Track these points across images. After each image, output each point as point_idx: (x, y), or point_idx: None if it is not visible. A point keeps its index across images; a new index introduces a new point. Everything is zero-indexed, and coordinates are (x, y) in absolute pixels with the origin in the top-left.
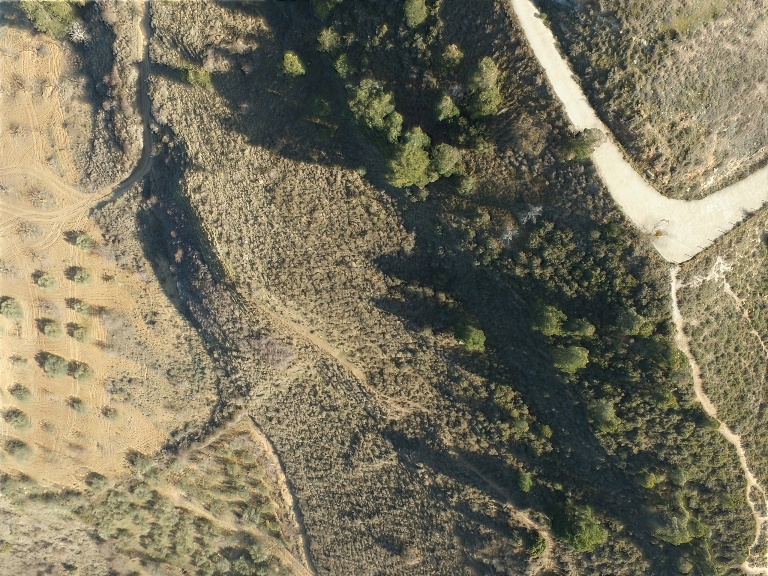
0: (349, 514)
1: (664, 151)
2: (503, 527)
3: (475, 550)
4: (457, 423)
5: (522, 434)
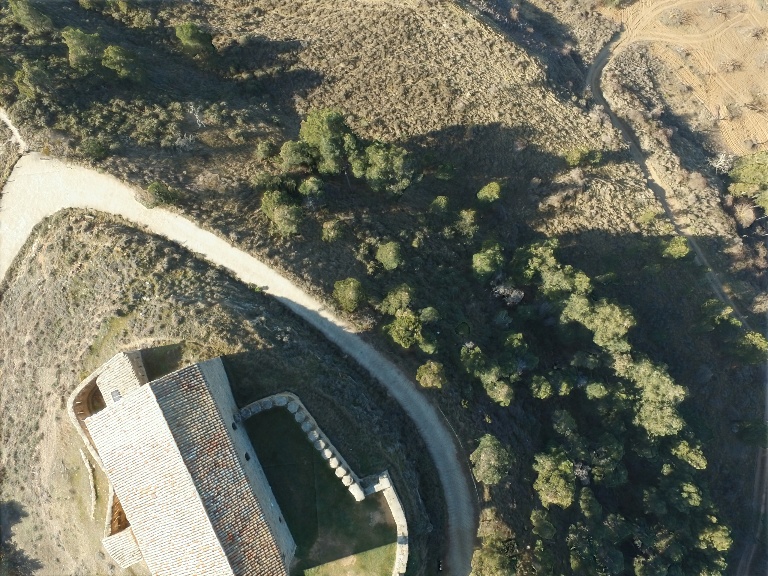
0: None
1: (85, 236)
2: None
3: None
4: None
5: None
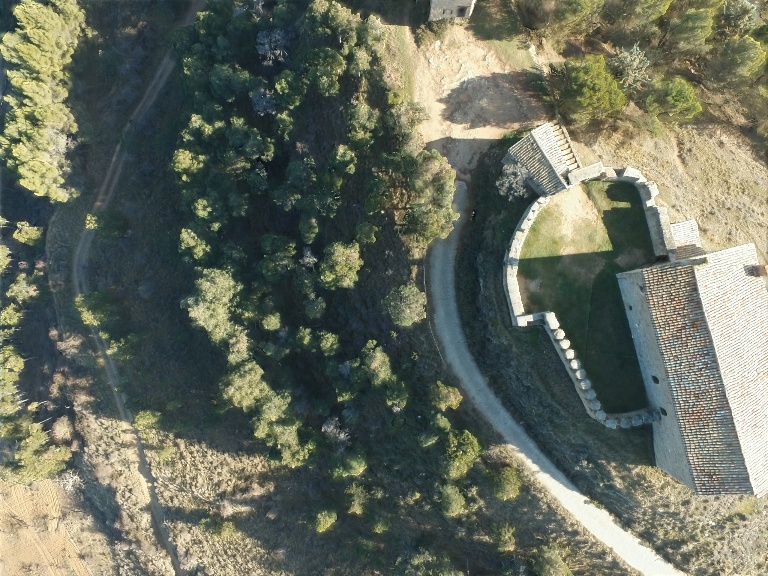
0: None
1: None
2: None
3: None
4: None
5: None
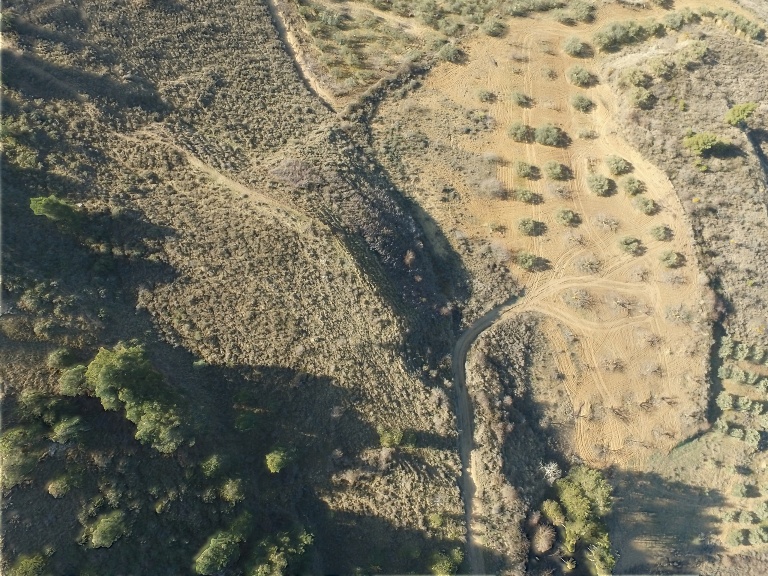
0: (218, 29)
1: None
2: (28, 30)
3: (62, 6)
4: (82, 125)
5: (6, 122)
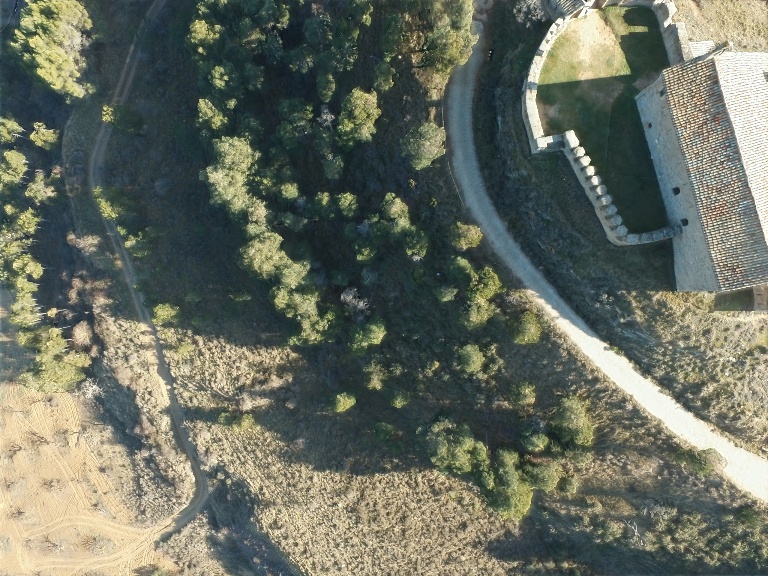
0: None
1: None
2: None
3: None
4: None
5: None
